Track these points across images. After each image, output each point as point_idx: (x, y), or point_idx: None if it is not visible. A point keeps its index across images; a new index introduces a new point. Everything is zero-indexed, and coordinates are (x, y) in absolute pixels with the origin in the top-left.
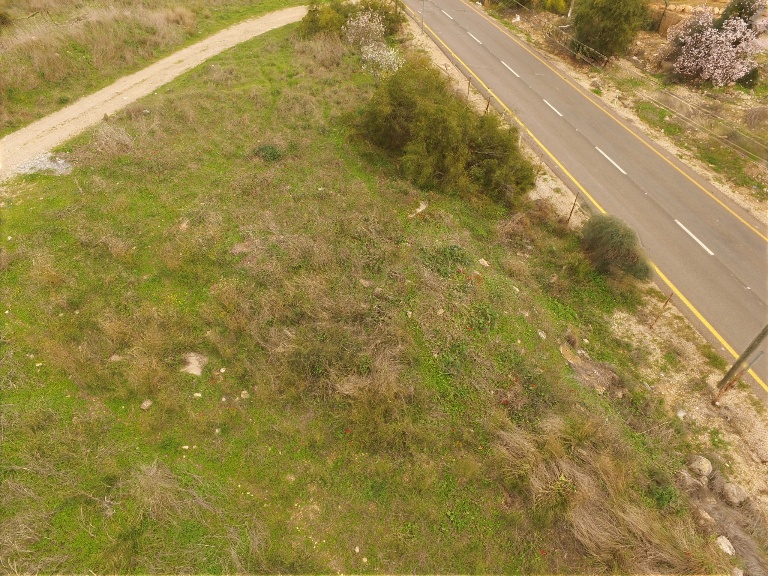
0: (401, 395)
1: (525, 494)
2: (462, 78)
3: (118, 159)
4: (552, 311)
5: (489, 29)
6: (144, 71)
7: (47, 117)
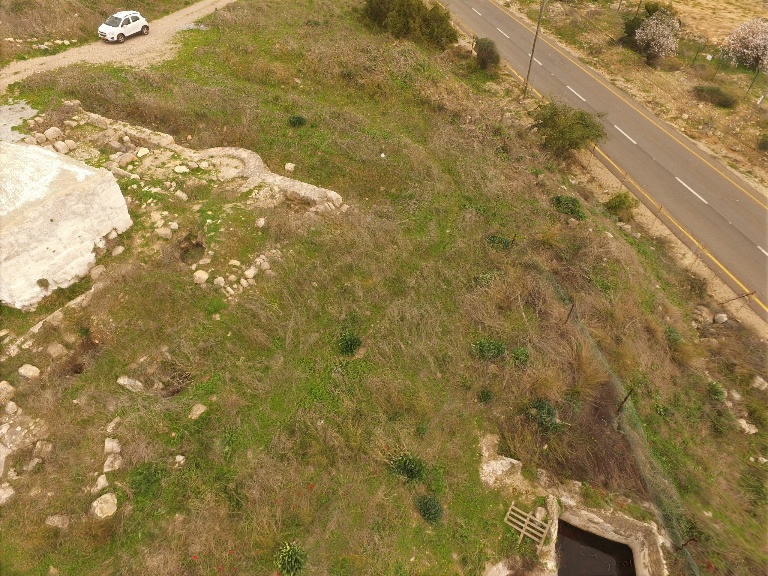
0: (384, 82)
1: (430, 103)
2: None
3: (233, 25)
4: (456, 80)
5: None
6: None
7: (181, 10)
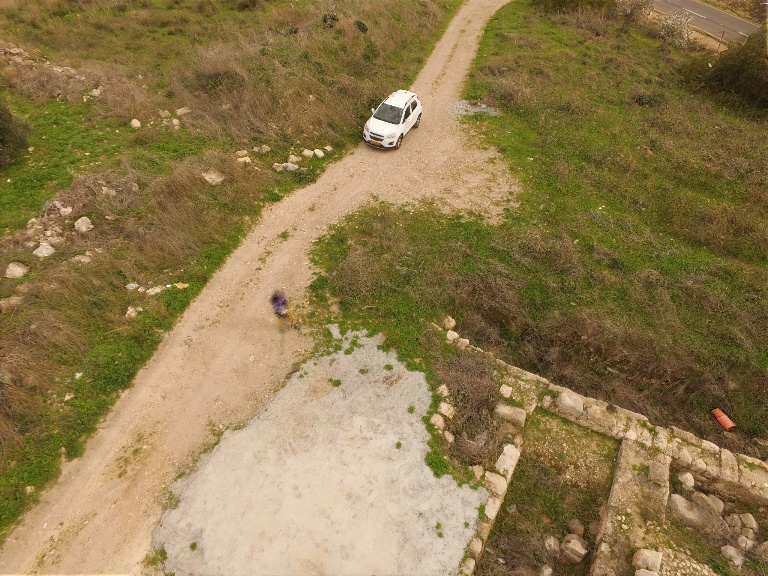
0: None
1: None
2: (723, 45)
3: None
4: None
5: (698, 6)
6: (445, 38)
7: (421, 73)
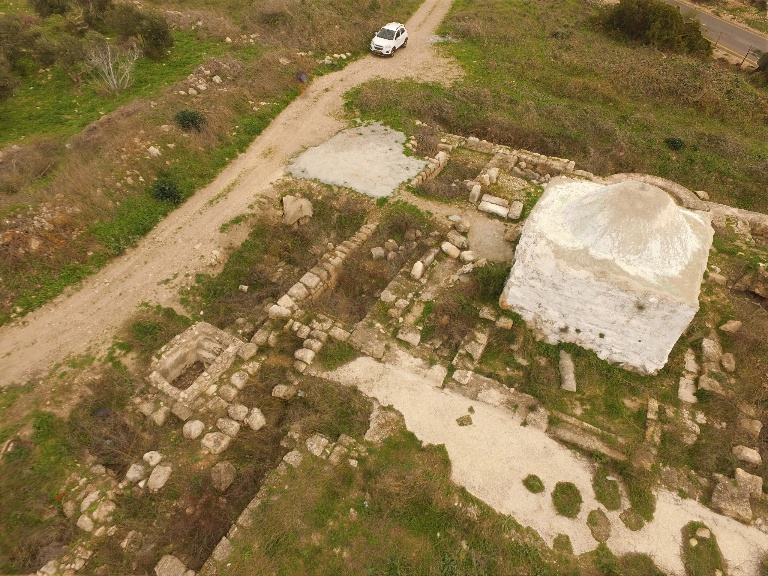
0: None
1: None
2: None
3: None
4: None
5: None
6: (428, 2)
7: (409, 21)
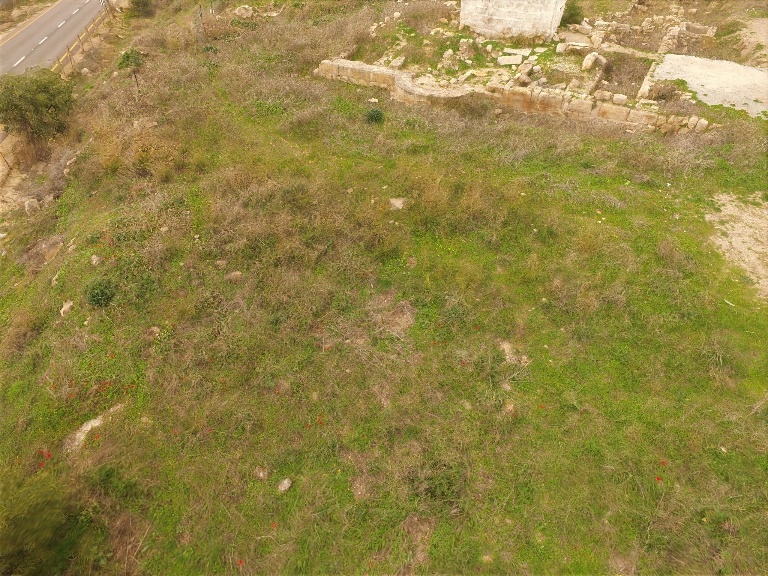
0: None
1: None
2: None
3: None
4: None
5: None
6: None
7: None
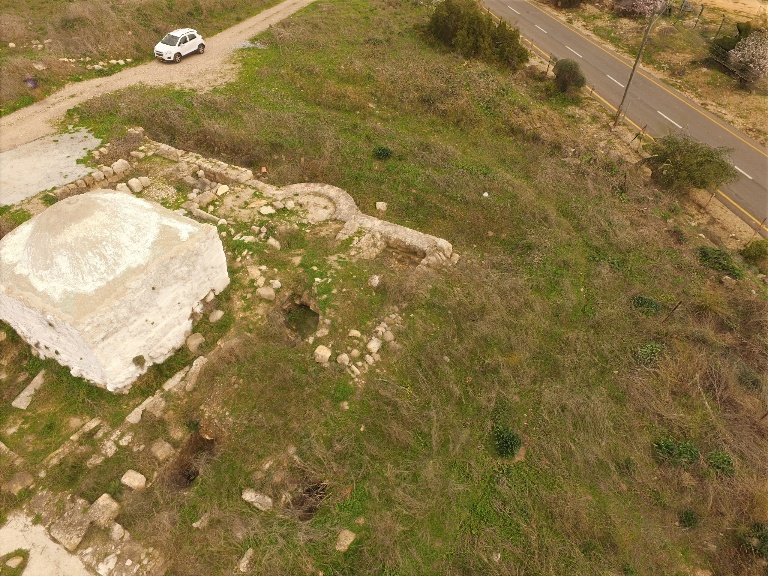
0: None
1: (522, 133)
2: None
3: (291, 43)
4: None
5: None
6: (275, 8)
7: (234, 27)
